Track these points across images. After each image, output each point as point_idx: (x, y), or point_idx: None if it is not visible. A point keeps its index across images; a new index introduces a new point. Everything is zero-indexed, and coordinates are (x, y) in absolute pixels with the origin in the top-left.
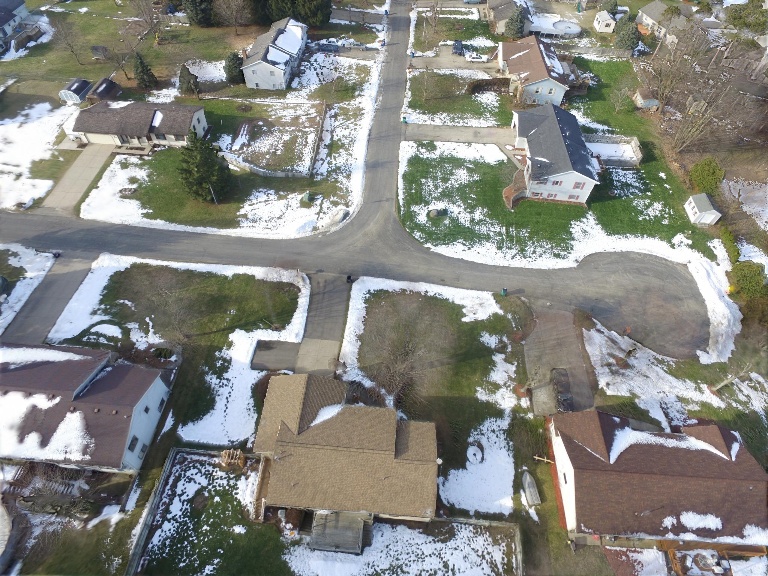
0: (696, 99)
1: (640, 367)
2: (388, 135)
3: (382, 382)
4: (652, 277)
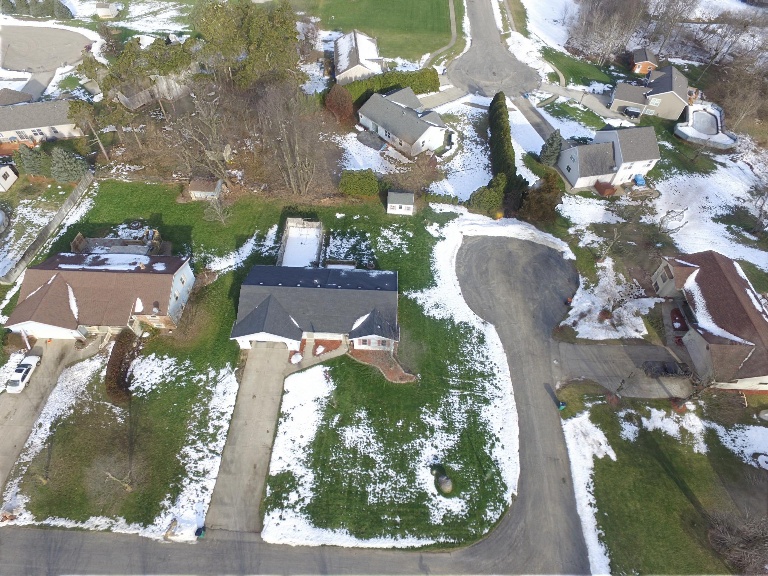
0: (219, 150)
1: (602, 302)
2: (240, 571)
3: (758, 570)
4: (489, 265)
